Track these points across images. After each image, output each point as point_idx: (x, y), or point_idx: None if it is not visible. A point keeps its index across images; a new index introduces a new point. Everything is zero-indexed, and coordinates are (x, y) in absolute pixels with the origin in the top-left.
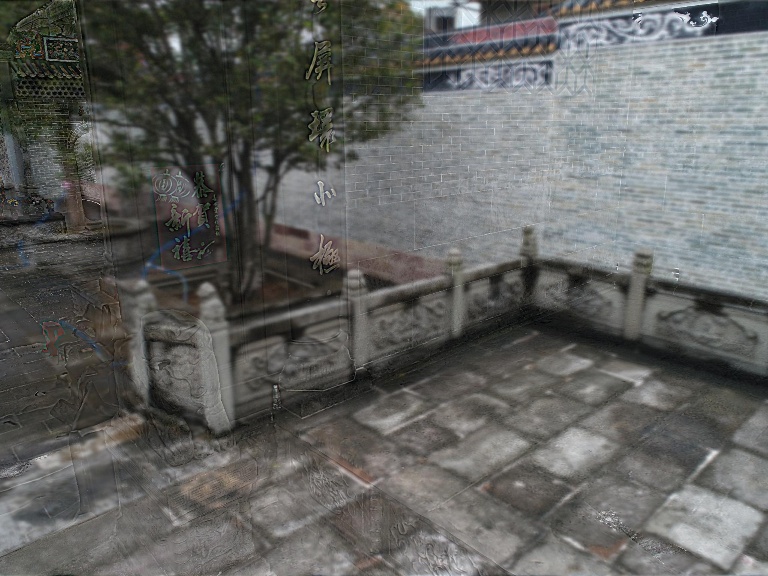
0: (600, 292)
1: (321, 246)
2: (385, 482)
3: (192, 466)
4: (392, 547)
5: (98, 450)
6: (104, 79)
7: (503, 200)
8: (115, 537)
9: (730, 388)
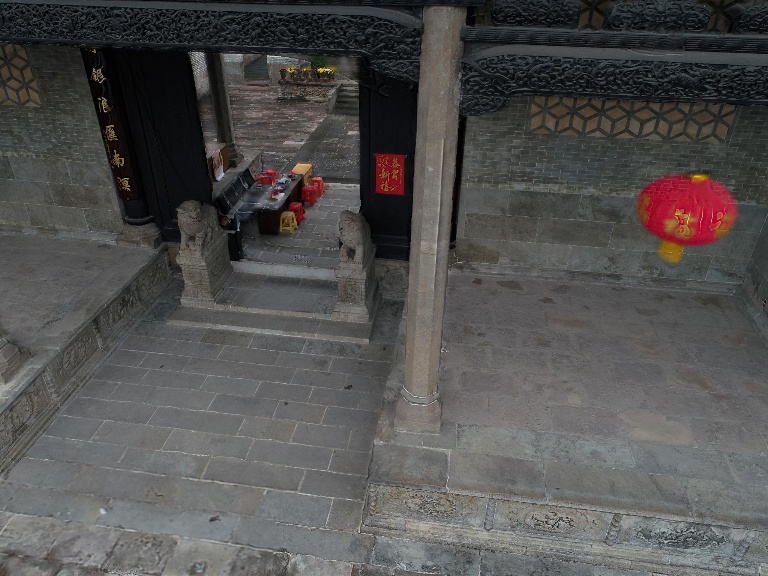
0: (707, 291)
1: None
2: (405, 303)
3: (345, 264)
4: None
5: None
6: (363, 121)
7: (593, 202)
8: None
9: (612, 363)
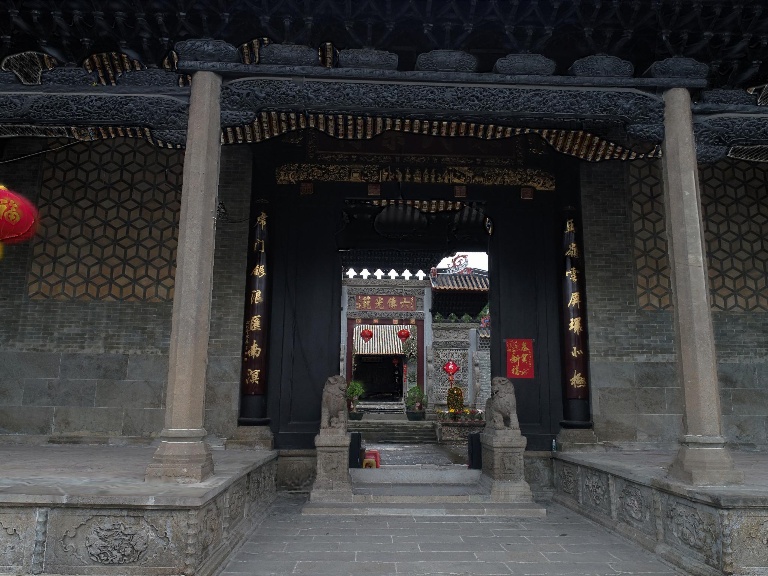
0: None
1: (575, 375)
2: None
3: (502, 431)
4: None
5: (477, 441)
6: (494, 310)
7: None
8: None
9: None
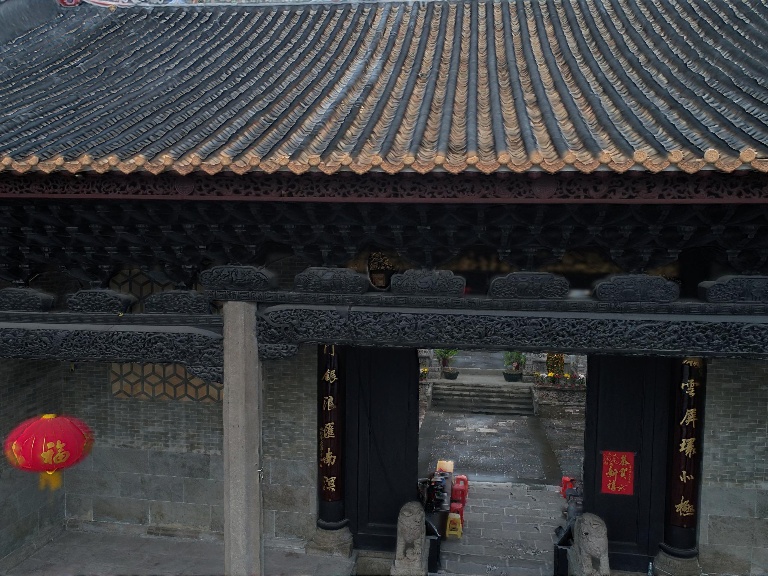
0: None
1: (682, 502)
2: None
3: None
4: None
5: (564, 557)
6: (590, 418)
7: None
8: None
9: None
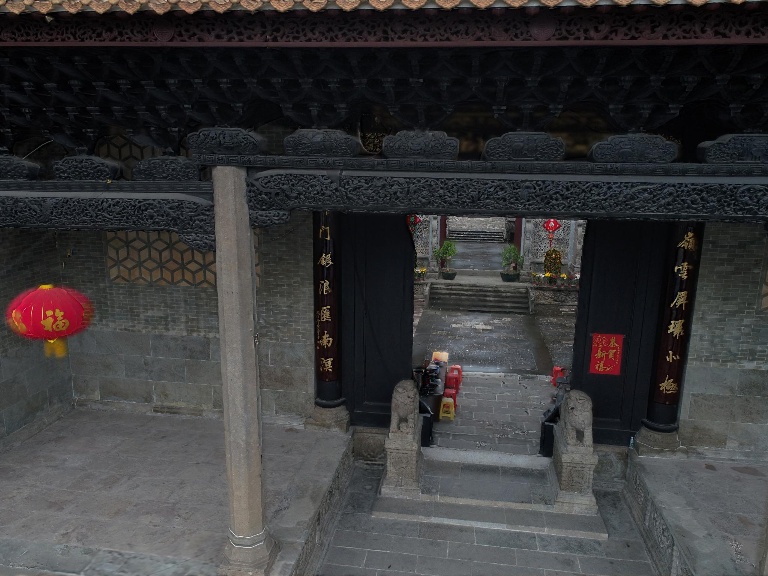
0: None
1: (666, 380)
2: (652, 491)
3: (574, 447)
4: (651, 523)
5: (550, 432)
6: (582, 302)
7: None
8: (548, 468)
9: None
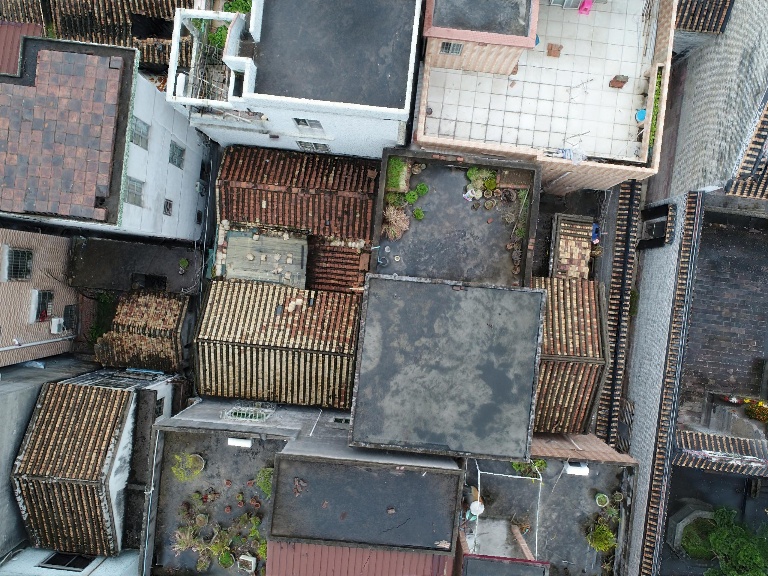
0: None
1: None
2: None
3: None
4: None
5: None
6: None
7: None
8: None
9: None
